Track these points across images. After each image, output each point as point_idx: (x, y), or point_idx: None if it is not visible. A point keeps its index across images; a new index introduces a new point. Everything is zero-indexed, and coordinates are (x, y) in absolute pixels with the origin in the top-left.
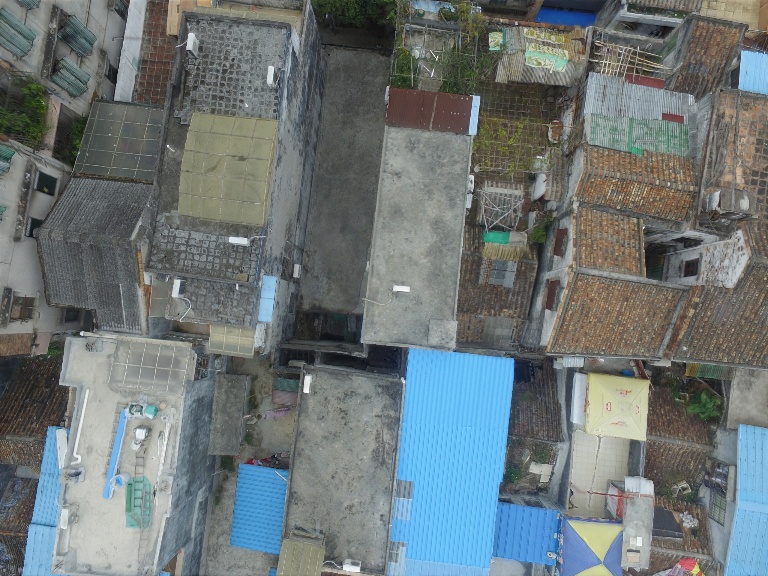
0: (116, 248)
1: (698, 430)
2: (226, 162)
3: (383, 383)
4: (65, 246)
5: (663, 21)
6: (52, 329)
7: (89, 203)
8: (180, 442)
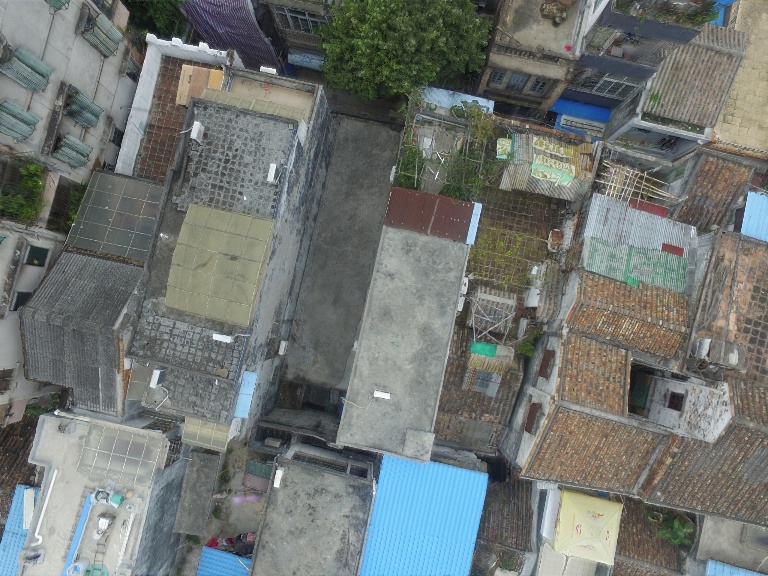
0: (98, 335)
1: (668, 553)
2: (217, 260)
3: (355, 483)
4: (48, 327)
5: (676, 133)
6: (29, 395)
7: (77, 282)
8: (143, 534)
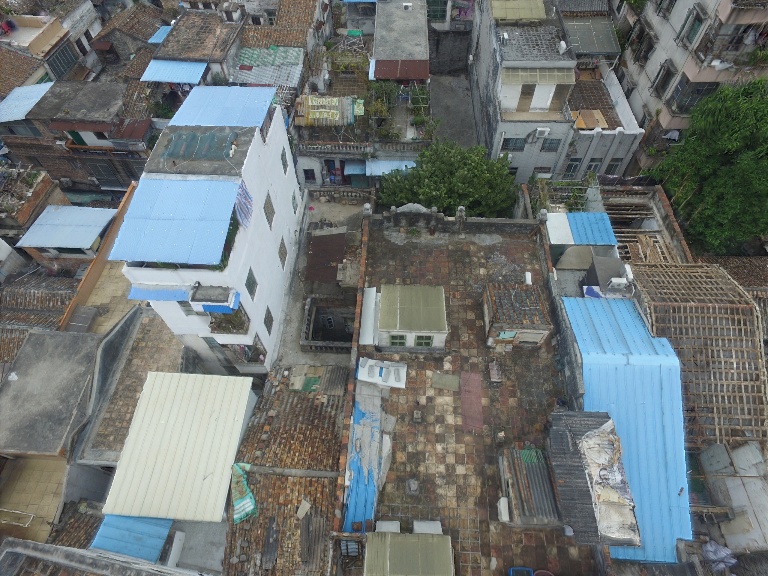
0: None
1: None
2: None
3: None
4: None
5: None
6: None
7: None
8: None
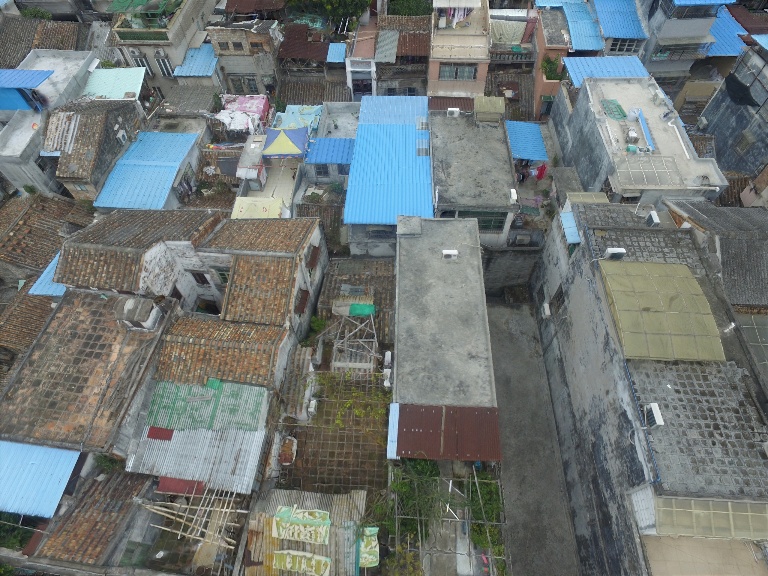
0: None
1: None
2: (662, 305)
3: None
4: None
5: None
6: None
7: None
8: None
